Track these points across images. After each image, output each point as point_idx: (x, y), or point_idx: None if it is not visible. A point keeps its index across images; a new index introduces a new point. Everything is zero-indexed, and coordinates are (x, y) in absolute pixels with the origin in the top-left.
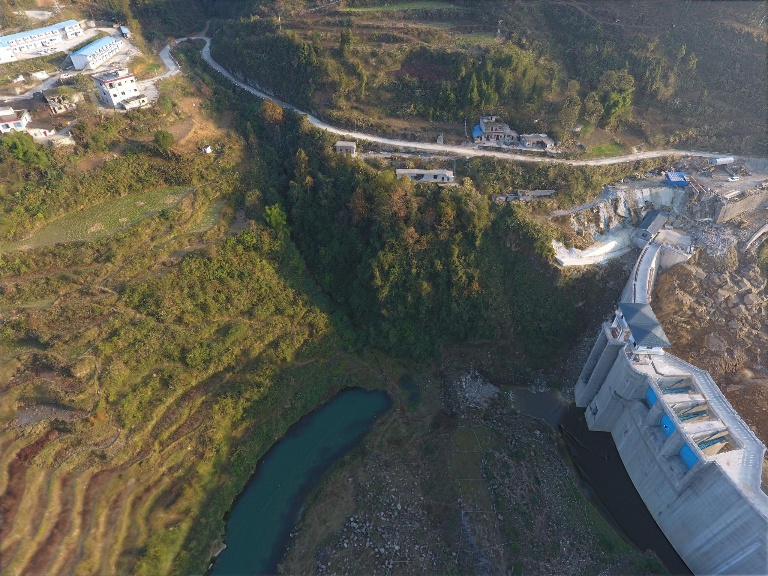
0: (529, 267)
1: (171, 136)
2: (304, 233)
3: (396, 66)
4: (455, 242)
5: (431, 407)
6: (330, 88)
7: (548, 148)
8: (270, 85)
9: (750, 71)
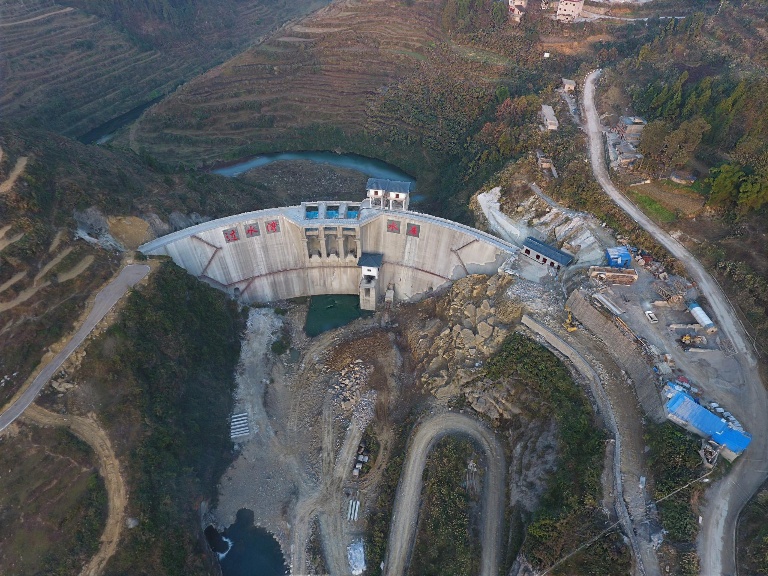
0: None
1: (537, 35)
2: None
3: (695, 63)
4: None
5: None
6: None
7: (618, 162)
8: None
9: None
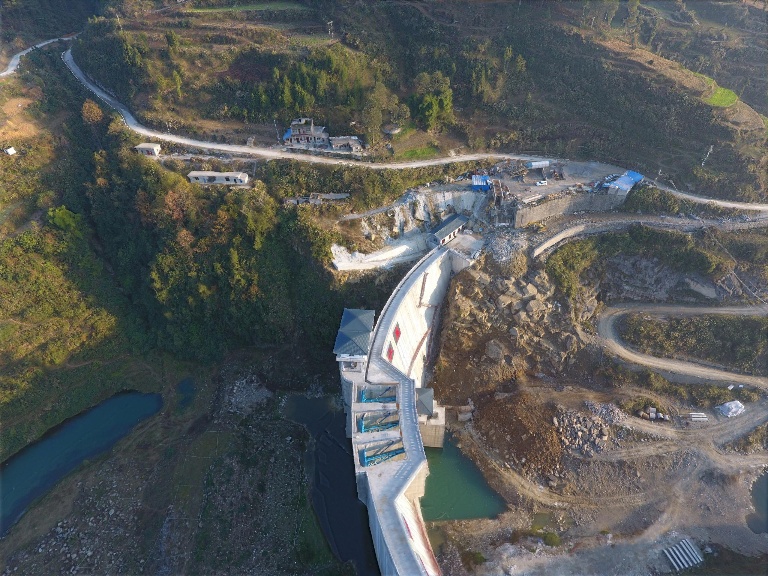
0: (310, 271)
1: None
2: (109, 235)
3: (223, 67)
4: (234, 245)
5: (197, 411)
6: (152, 89)
7: (355, 151)
8: (109, 86)
9: (579, 73)
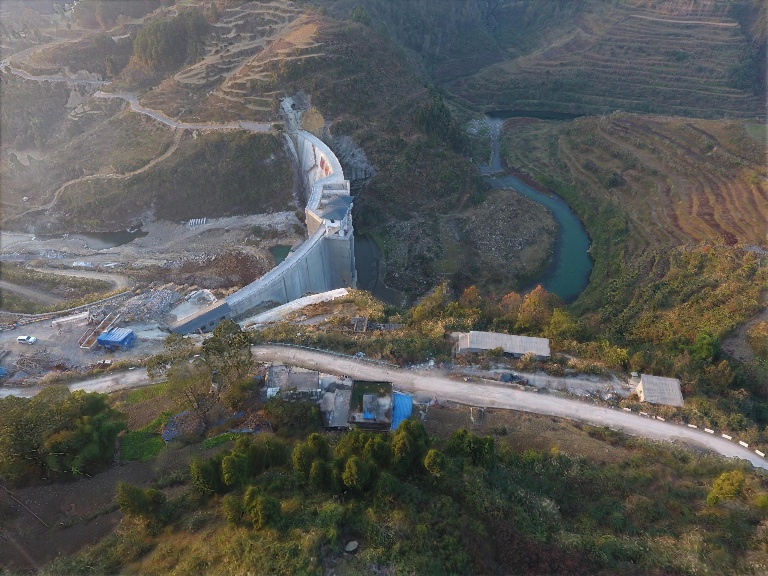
0: None
1: None
2: None
3: None
4: None
5: None
6: None
7: None
8: None
9: None
